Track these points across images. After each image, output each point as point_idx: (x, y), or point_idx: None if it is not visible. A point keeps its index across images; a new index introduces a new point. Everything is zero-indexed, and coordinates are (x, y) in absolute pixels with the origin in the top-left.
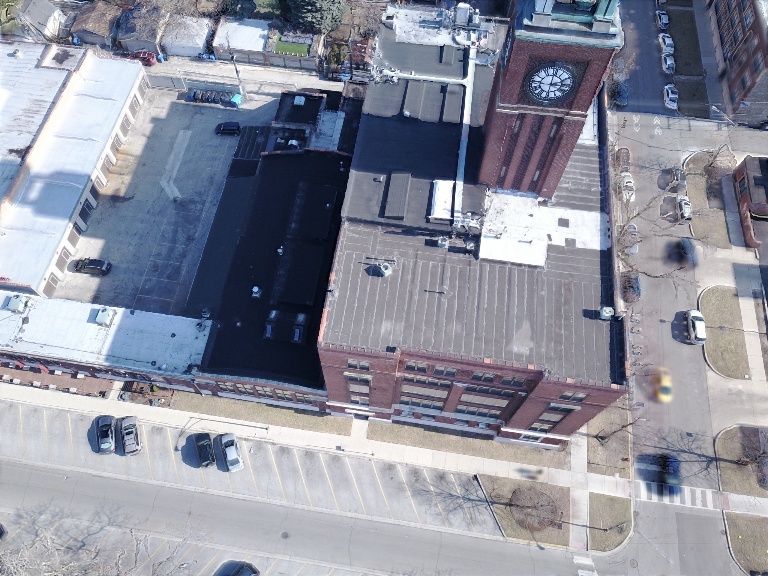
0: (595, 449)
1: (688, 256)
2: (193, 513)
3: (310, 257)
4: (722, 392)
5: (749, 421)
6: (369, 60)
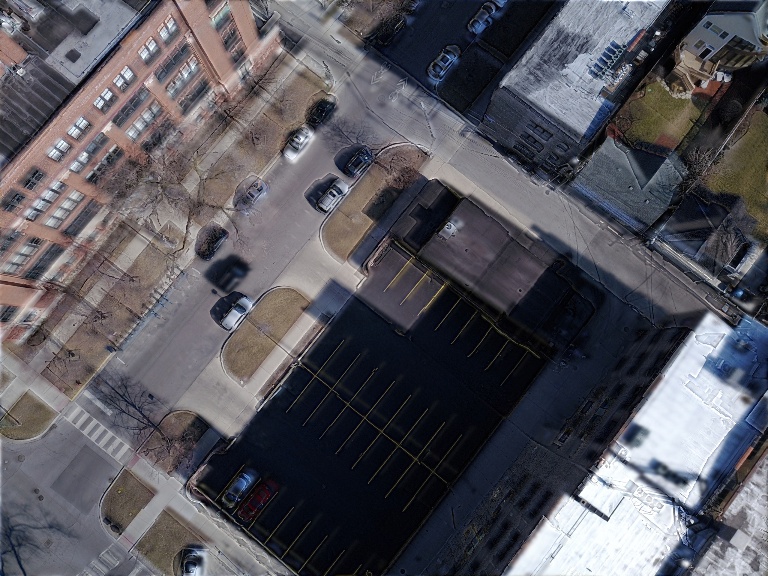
0: (61, 360)
1: (295, 246)
2: None
3: None
4: (211, 381)
5: (208, 417)
6: None
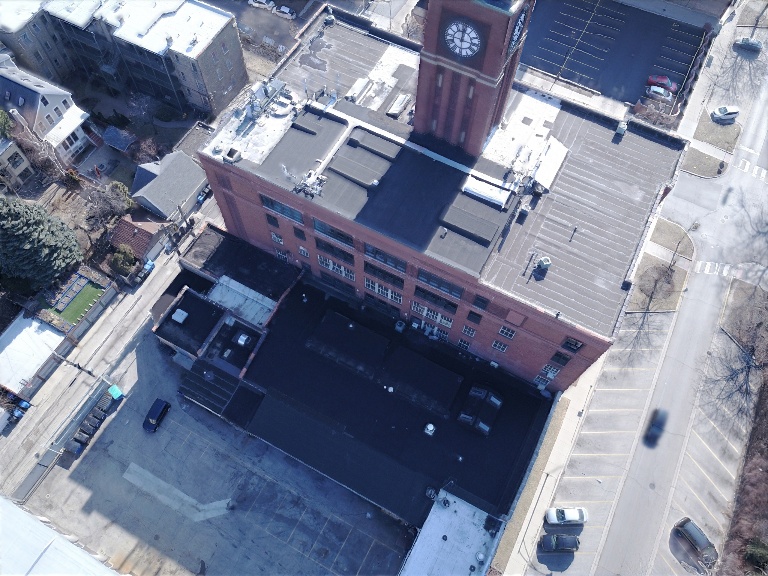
0: None
1: None
2: (619, 572)
3: (406, 363)
4: None
5: None
6: (153, 230)
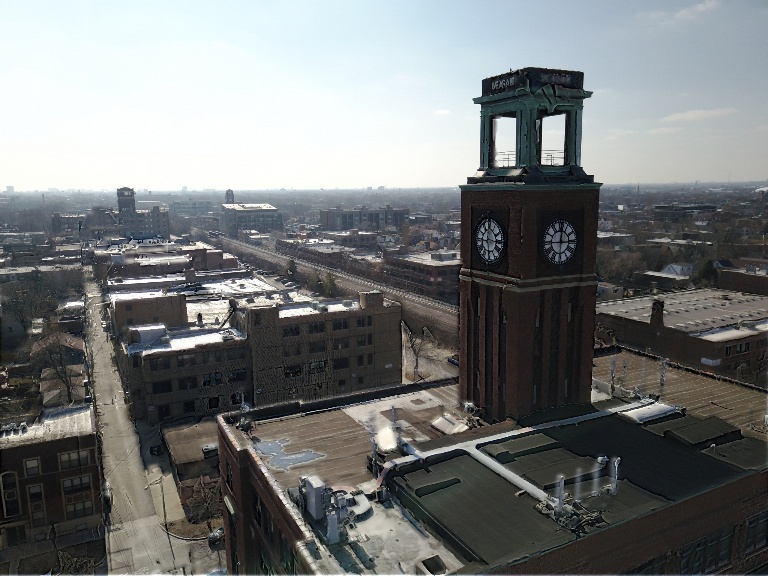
0: None
1: None
2: None
3: None
4: None
5: None
6: None
